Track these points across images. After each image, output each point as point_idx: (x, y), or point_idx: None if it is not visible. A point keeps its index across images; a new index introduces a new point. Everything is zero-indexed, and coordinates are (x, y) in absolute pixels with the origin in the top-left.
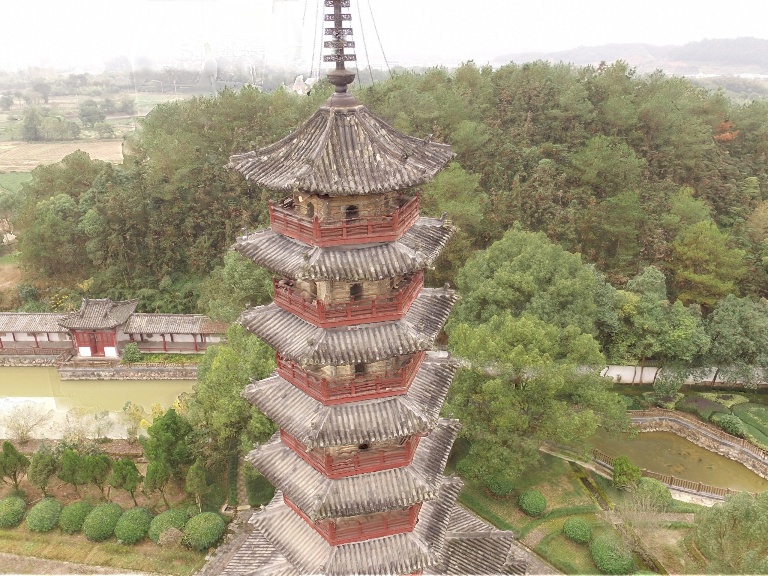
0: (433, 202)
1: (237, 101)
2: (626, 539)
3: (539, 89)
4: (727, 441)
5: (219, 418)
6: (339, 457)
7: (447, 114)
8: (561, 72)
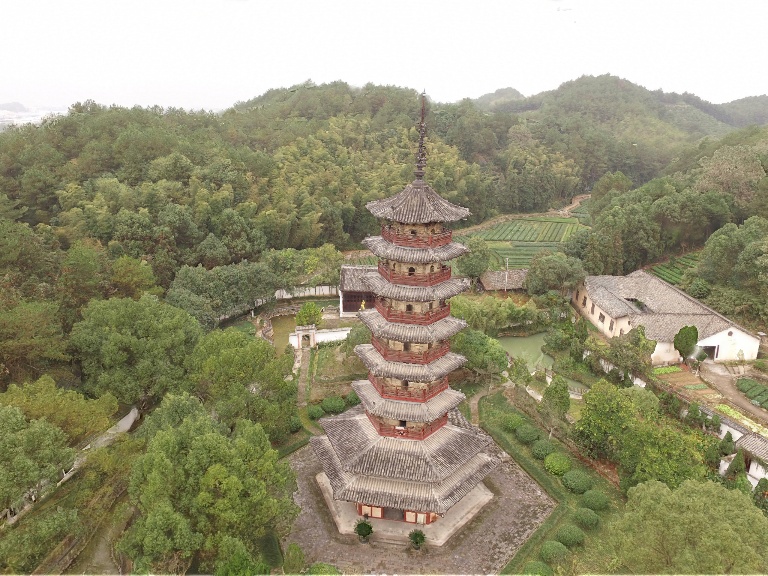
0: None
1: None
2: (332, 394)
3: None
4: None
5: (274, 502)
6: (443, 342)
7: None
8: None
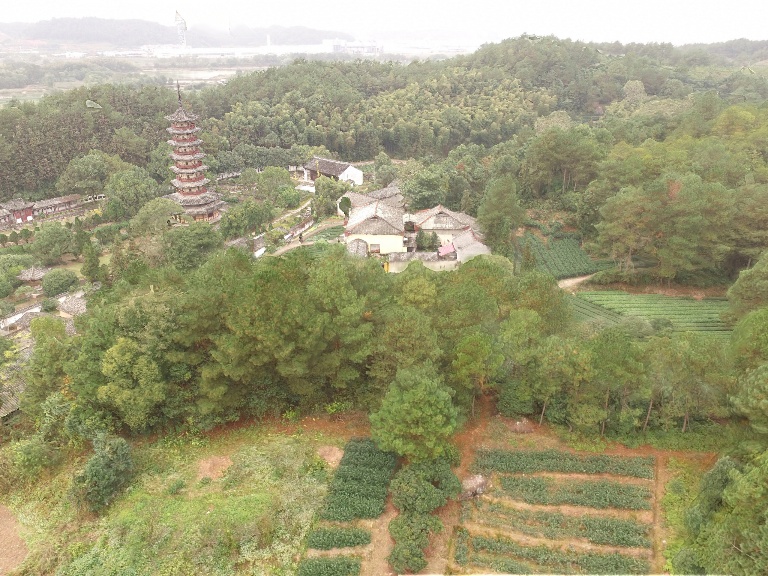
0: (124, 141)
1: (1, 115)
2: None
3: (123, 96)
4: (234, 185)
5: (132, 194)
6: (194, 165)
7: (102, 110)
8: (123, 88)
